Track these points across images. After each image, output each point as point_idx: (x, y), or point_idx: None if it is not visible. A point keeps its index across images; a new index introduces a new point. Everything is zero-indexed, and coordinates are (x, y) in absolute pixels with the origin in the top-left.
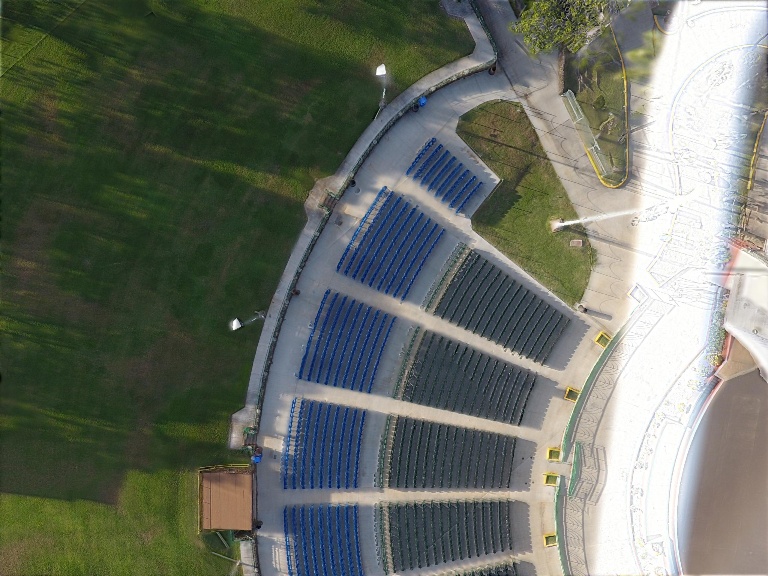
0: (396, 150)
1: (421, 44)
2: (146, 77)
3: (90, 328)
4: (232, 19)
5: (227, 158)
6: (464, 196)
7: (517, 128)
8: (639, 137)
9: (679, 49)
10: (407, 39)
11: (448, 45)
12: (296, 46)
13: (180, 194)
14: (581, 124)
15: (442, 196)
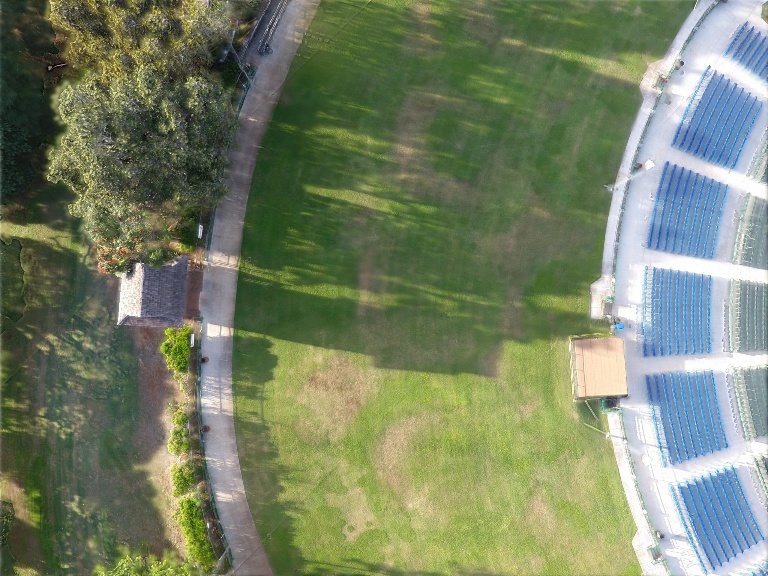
0: (712, 36)
1: None
2: None
3: (461, 207)
4: None
5: (573, 48)
6: None
7: None
8: None
9: None
10: None
11: None
12: None
13: (535, 82)
14: None
15: (758, 72)
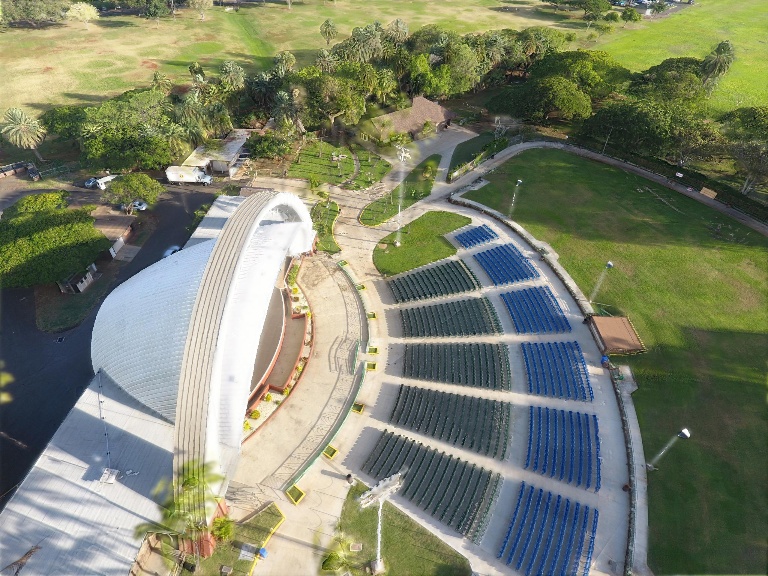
0: None
1: None
2: None
3: None
4: None
5: None
6: None
7: None
8: None
9: None
10: None
11: None
12: None
13: None
14: None
15: None
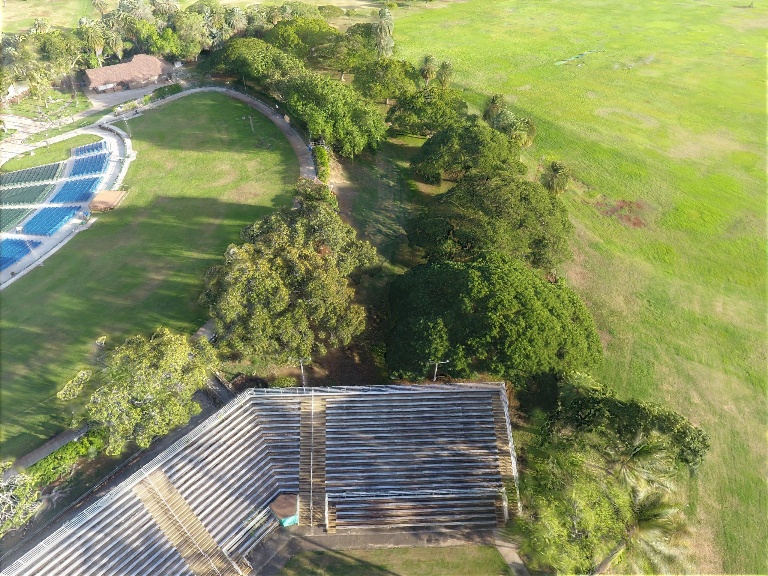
0: None
1: None
2: (20, 368)
3: None
4: None
5: (1, 330)
6: None
7: None
8: None
9: None
10: None
11: None
12: None
13: None
14: None
15: None
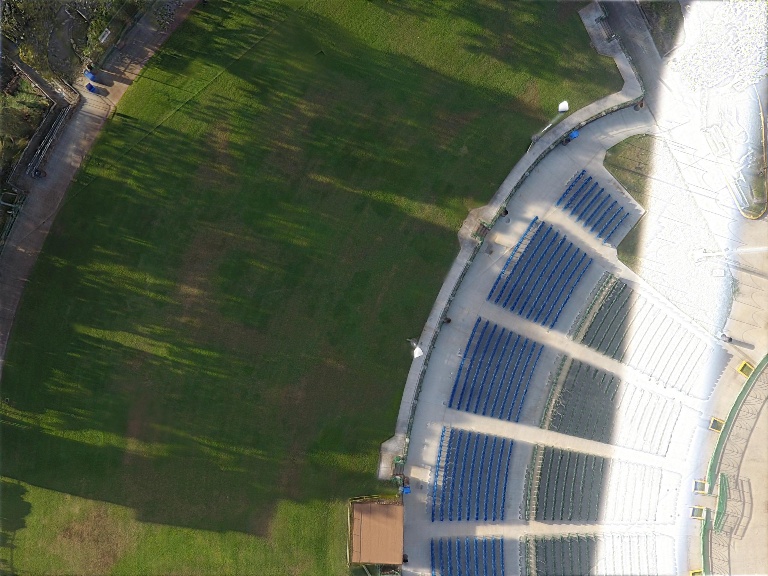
0: (546, 182)
1: (573, 82)
2: (313, 111)
3: (247, 355)
4: (396, 58)
5: (386, 189)
6: (612, 226)
7: (661, 161)
8: None
9: None
10: (560, 77)
11: (598, 83)
12: (455, 83)
13: (340, 223)
14: (722, 158)
15: (591, 226)
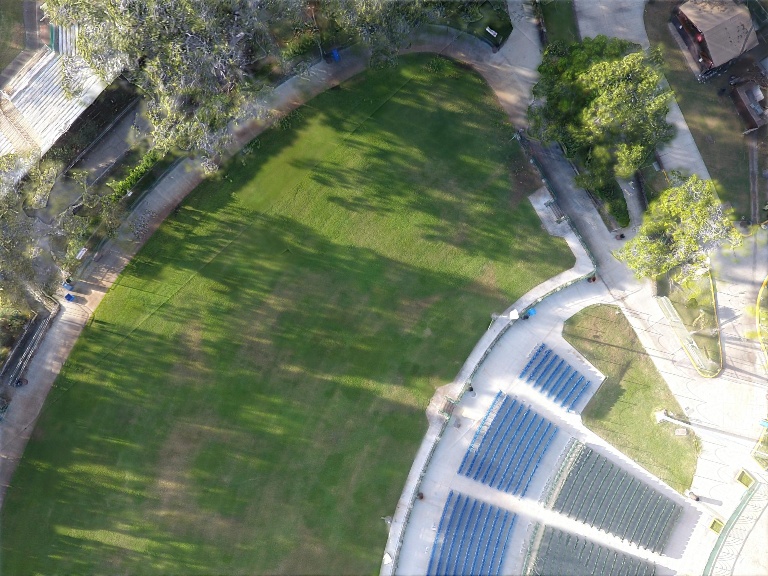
0: (508, 355)
1: (527, 262)
2: (282, 306)
3: (224, 544)
4: (359, 251)
5: (354, 373)
6: (574, 395)
7: (617, 328)
8: (729, 329)
9: (756, 249)
10: (515, 258)
11: (552, 261)
12: (416, 270)
13: (311, 409)
14: (675, 322)
15: (553, 396)
